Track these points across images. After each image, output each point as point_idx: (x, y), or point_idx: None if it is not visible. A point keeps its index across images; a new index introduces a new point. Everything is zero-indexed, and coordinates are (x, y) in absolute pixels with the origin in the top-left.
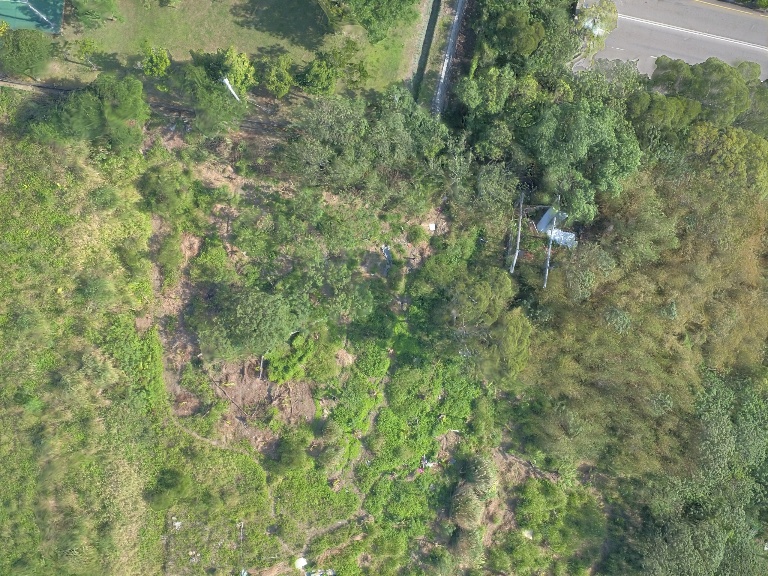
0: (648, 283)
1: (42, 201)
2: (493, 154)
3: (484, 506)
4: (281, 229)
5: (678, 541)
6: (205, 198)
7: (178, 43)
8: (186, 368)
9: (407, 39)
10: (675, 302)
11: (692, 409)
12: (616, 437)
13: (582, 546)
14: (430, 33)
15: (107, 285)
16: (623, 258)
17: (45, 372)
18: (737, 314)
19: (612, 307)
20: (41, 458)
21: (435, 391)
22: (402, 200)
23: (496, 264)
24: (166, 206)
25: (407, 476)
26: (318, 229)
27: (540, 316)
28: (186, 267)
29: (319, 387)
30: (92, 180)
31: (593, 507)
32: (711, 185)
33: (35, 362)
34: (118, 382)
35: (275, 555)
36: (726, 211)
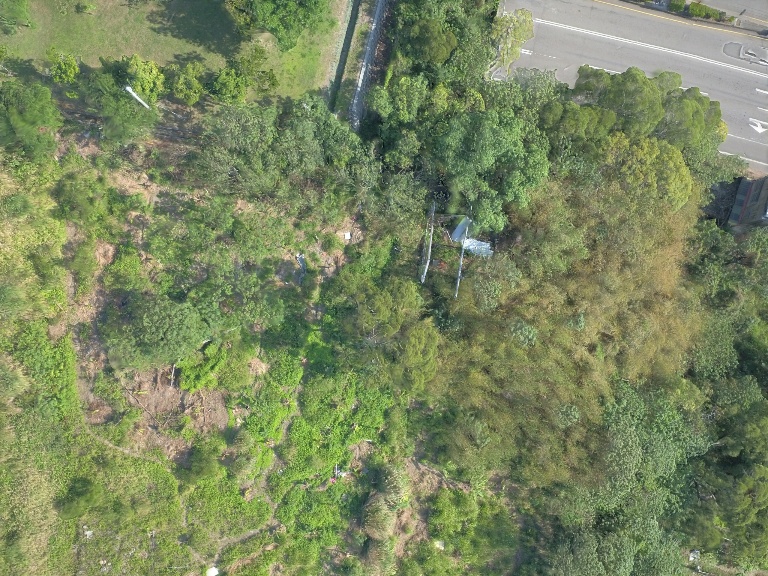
0: (558, 293)
1: None
2: (402, 163)
3: (396, 516)
4: (196, 237)
5: (583, 553)
6: (119, 205)
7: (94, 50)
8: (99, 376)
9: (324, 47)
10: (585, 313)
11: (600, 420)
12: (525, 448)
13: (494, 557)
14: (348, 41)
15: (17, 292)
16: (533, 268)
17: None
18: (651, 325)
19: (519, 318)
20: None
21: (348, 400)
22: (313, 209)
23: (410, 273)
24: (78, 213)
25: (319, 486)
26: (233, 237)
27: (451, 326)
28: (100, 274)
29: (232, 396)
30: (6, 187)
31: (504, 518)
32: (619, 196)
33: None
34: (30, 390)
35: (186, 565)
36: (635, 222)
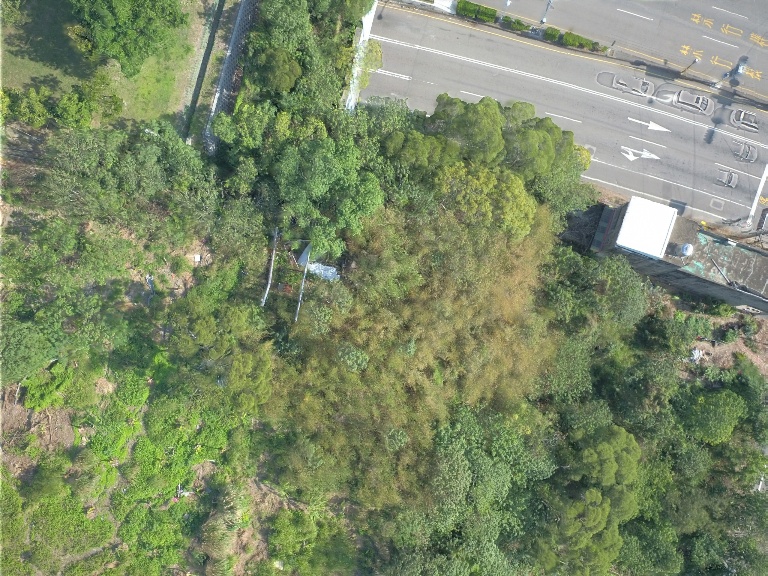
0: (395, 319)
1: None
2: (240, 189)
3: (236, 536)
4: None
5: (406, 575)
6: None
7: None
8: None
9: (179, 72)
10: (420, 338)
11: (430, 444)
12: (359, 471)
13: None
14: (205, 67)
15: None
16: (369, 294)
17: None
18: (491, 350)
19: (349, 343)
20: None
21: (193, 421)
22: None
23: (255, 296)
24: None
25: (162, 505)
26: None
27: (290, 349)
28: None
29: (77, 415)
30: None
31: (342, 539)
32: (452, 225)
33: None
34: None
35: None
36: (467, 250)
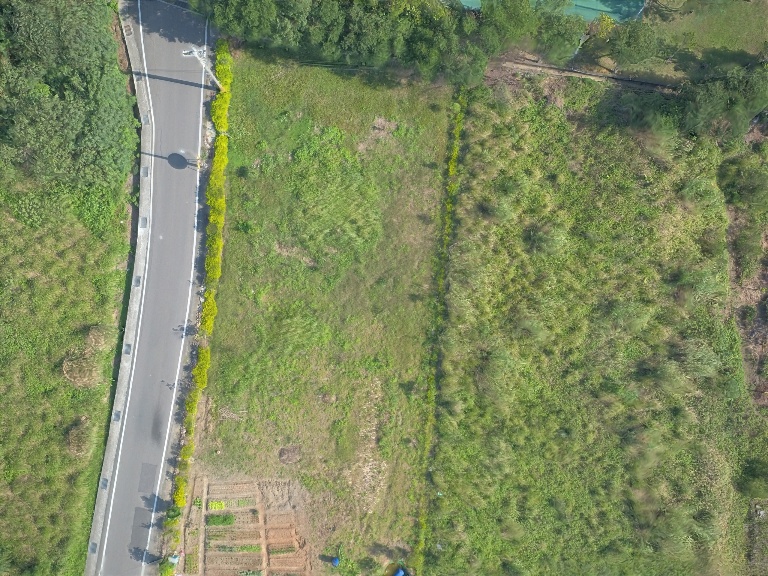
0: None
1: (627, 192)
2: None
3: None
4: None
5: None
6: None
7: (753, 36)
8: (766, 358)
9: None
10: None
11: None
12: None
13: None
14: None
15: None
16: None
17: (631, 361)
18: None
19: None
20: (651, 446)
21: None
22: None
23: None
24: (761, 197)
25: None
26: None
27: None
28: (763, 258)
29: None
30: (676, 171)
31: None
32: None
33: (621, 351)
34: None
35: None
36: None
